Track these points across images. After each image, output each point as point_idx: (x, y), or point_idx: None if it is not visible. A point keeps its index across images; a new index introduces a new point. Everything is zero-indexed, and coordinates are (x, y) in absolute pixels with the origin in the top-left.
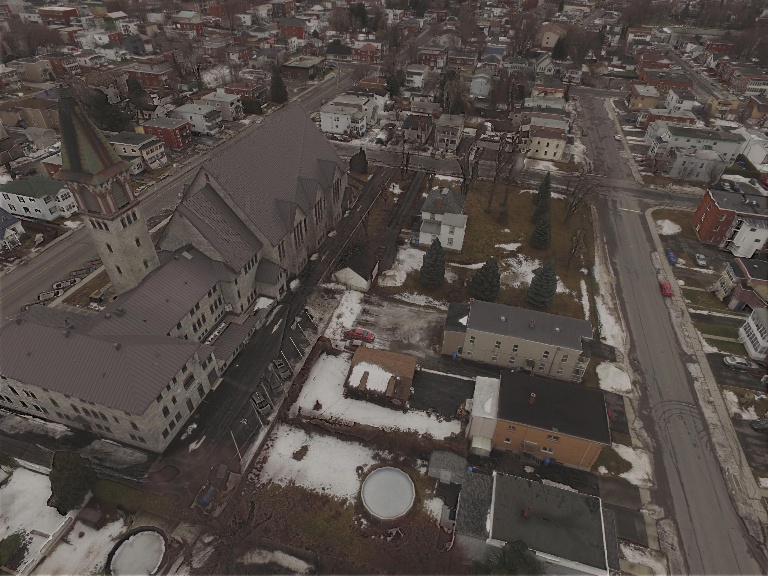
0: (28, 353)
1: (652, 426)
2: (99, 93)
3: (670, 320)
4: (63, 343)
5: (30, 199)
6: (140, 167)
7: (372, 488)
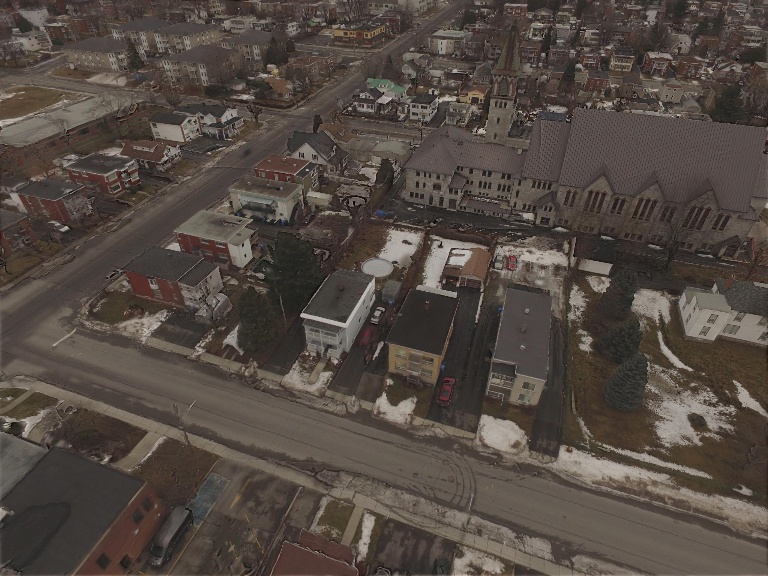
0: None
1: (438, 444)
2: (734, 87)
3: (655, 575)
4: None
5: None
6: None
7: (381, 262)
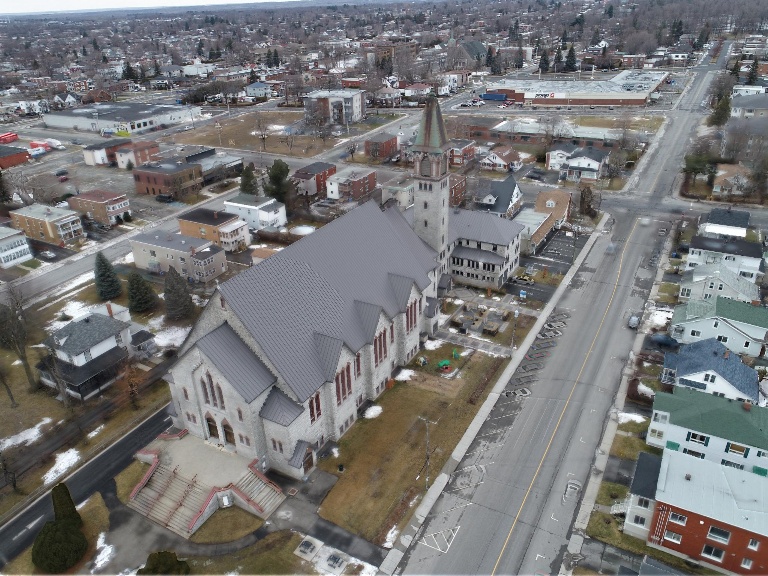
0: None
1: None
2: None
3: (33, 279)
4: None
5: None
6: None
7: None
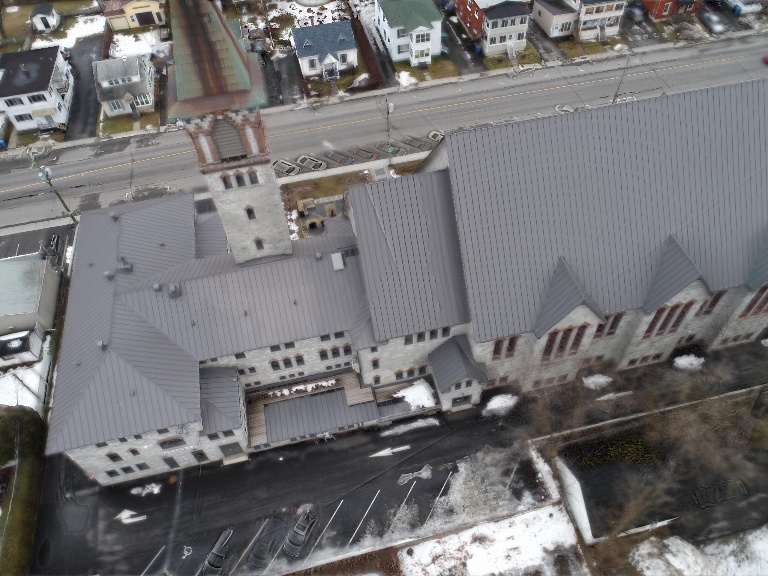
0: (90, 263)
1: None
2: None
3: None
4: (104, 283)
5: (388, 23)
6: (566, 28)
7: None
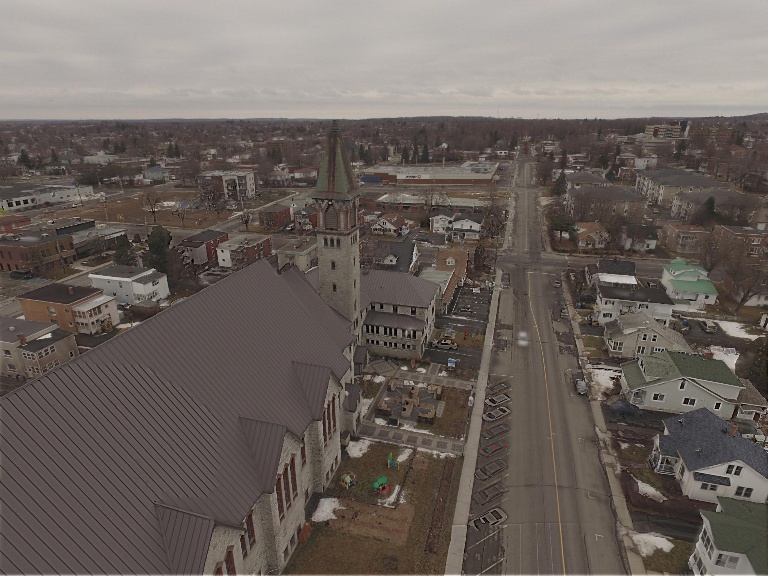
0: None
1: None
2: None
3: None
4: None
5: None
6: None
7: None
